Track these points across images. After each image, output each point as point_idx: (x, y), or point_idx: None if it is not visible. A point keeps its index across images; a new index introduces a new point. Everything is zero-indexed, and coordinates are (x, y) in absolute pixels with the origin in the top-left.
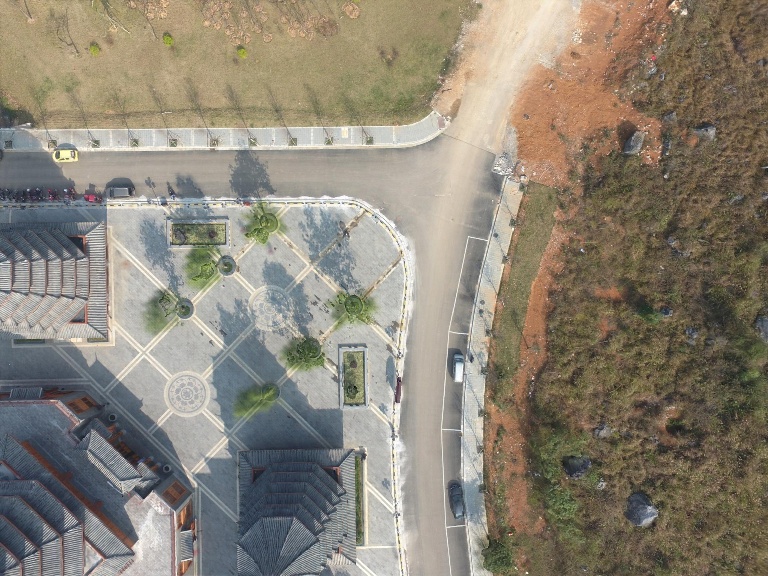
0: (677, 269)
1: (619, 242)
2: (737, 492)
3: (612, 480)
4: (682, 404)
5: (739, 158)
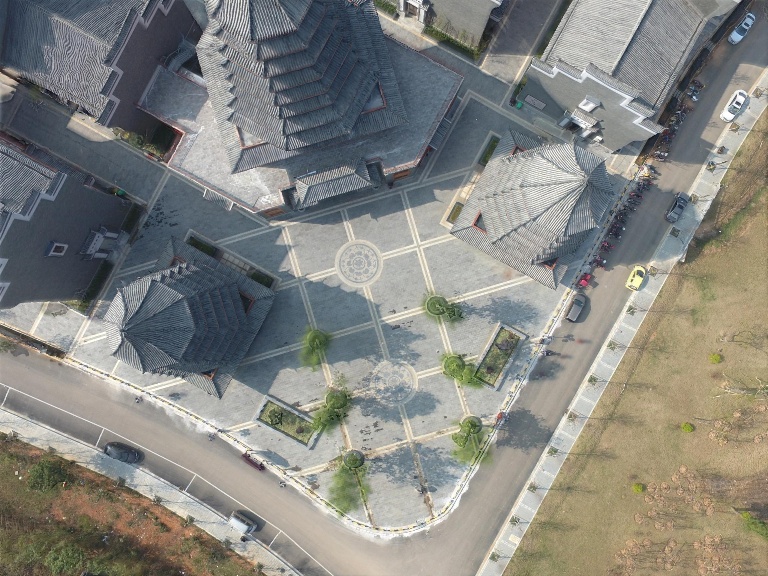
0: None
1: None
2: None
3: None
4: None
5: None
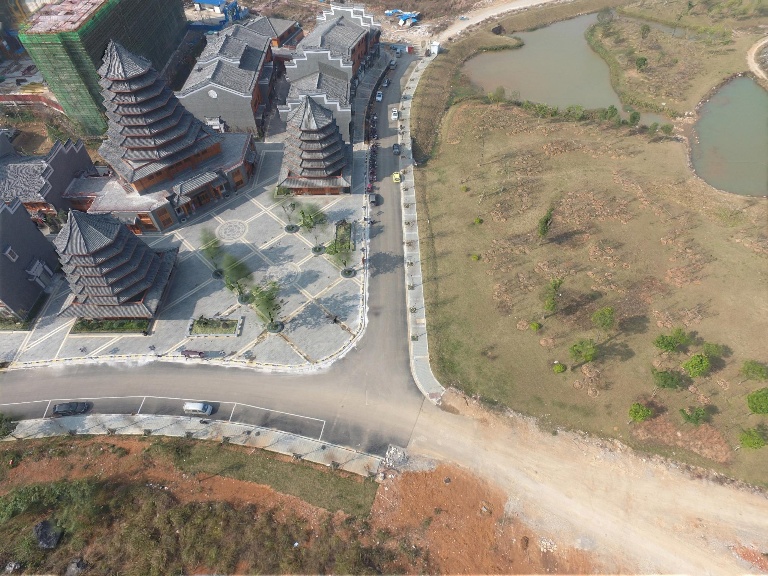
0: None
1: None
2: None
3: None
4: None
5: None
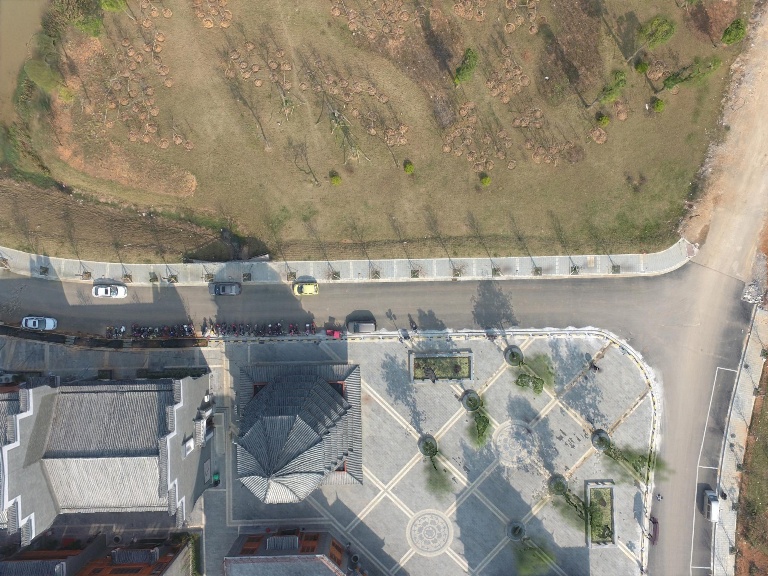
0: None
1: None
2: None
3: None
4: None
5: None
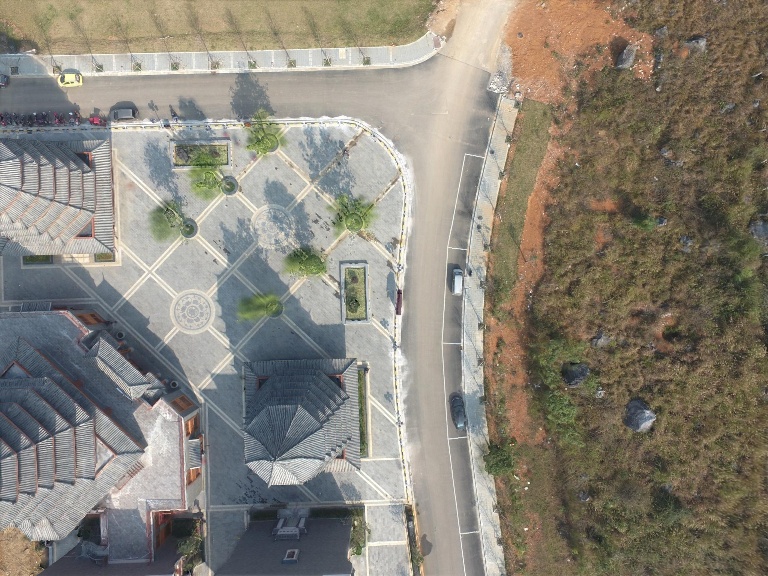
0: (671, 179)
1: (613, 155)
2: (733, 393)
3: (610, 388)
4: (678, 310)
5: (730, 68)
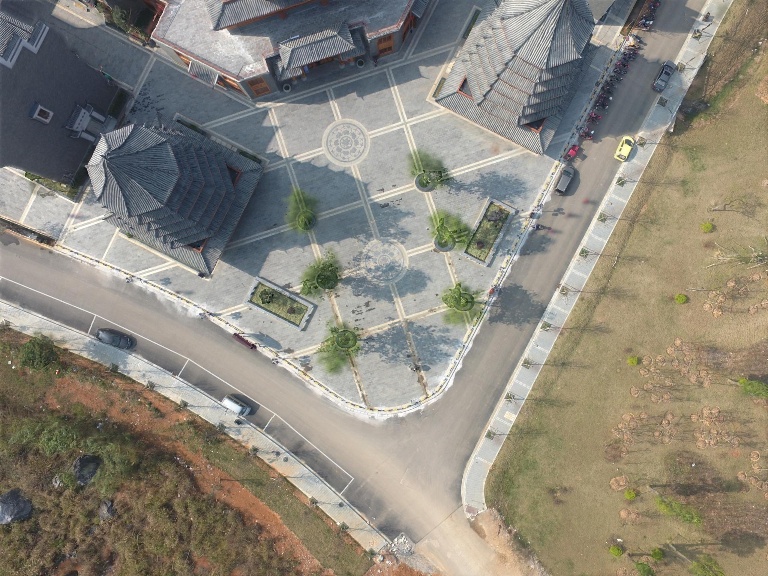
0: None
1: None
2: None
3: (56, 494)
4: None
5: None
